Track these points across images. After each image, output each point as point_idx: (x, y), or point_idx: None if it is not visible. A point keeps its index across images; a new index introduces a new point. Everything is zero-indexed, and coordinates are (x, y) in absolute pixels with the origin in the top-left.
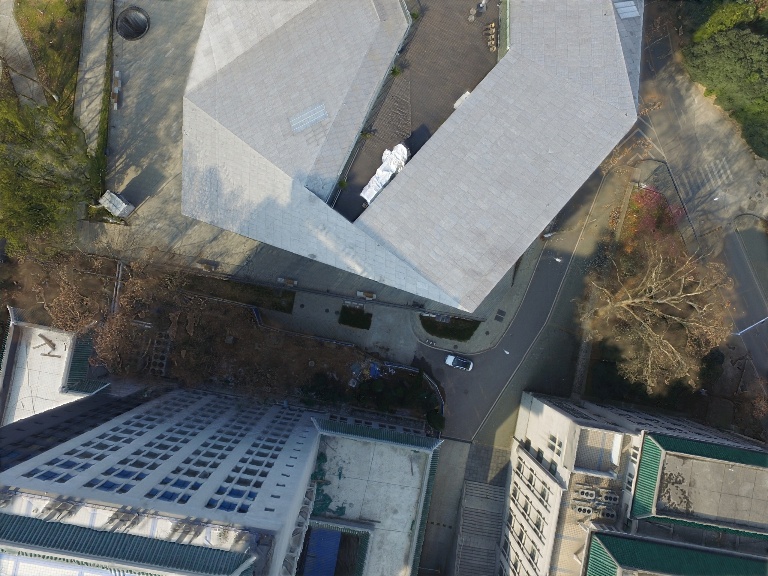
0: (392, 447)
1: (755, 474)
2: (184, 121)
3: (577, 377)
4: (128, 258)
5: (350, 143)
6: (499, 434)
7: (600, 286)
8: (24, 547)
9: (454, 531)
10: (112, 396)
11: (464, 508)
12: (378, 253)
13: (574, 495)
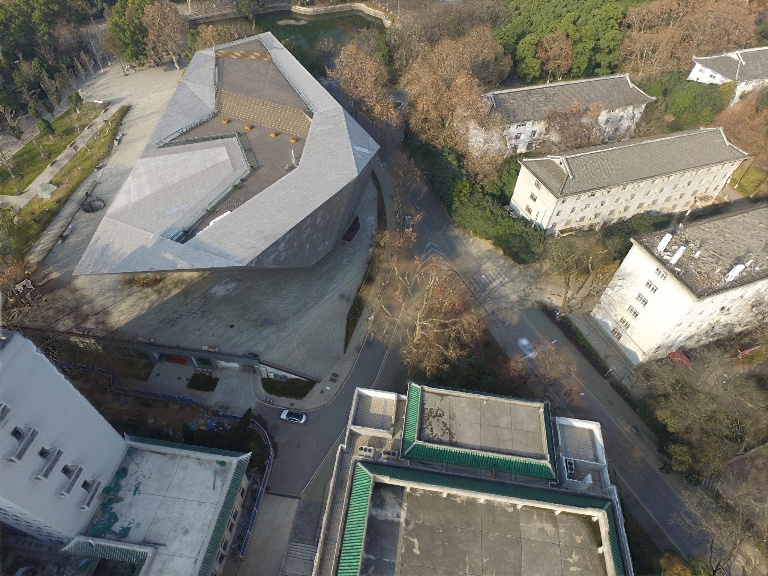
0: (198, 461)
1: (509, 408)
2: (99, 227)
3: None
4: None
5: (199, 217)
6: None
7: None
8: None
9: None
10: None
11: (282, 572)
12: (194, 253)
13: None
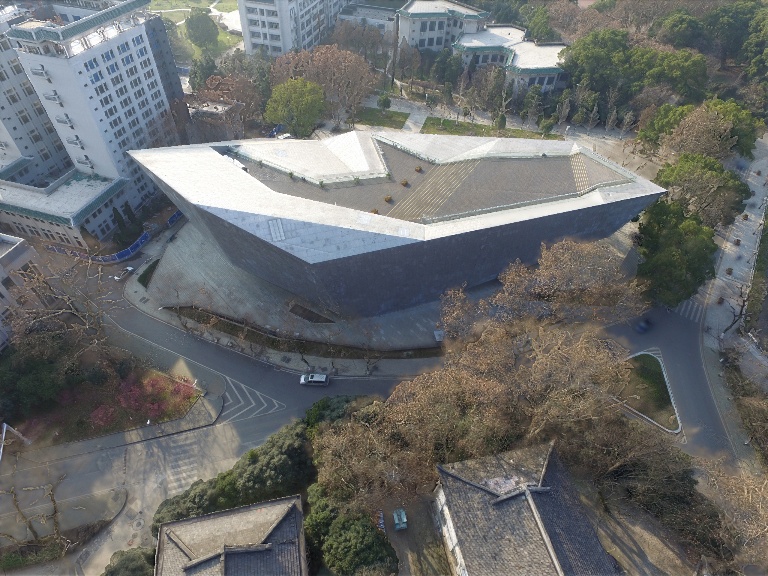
0: None
1: None
2: None
3: None
4: None
5: None
6: None
7: None
8: None
9: None
10: None
11: None
12: None
13: None
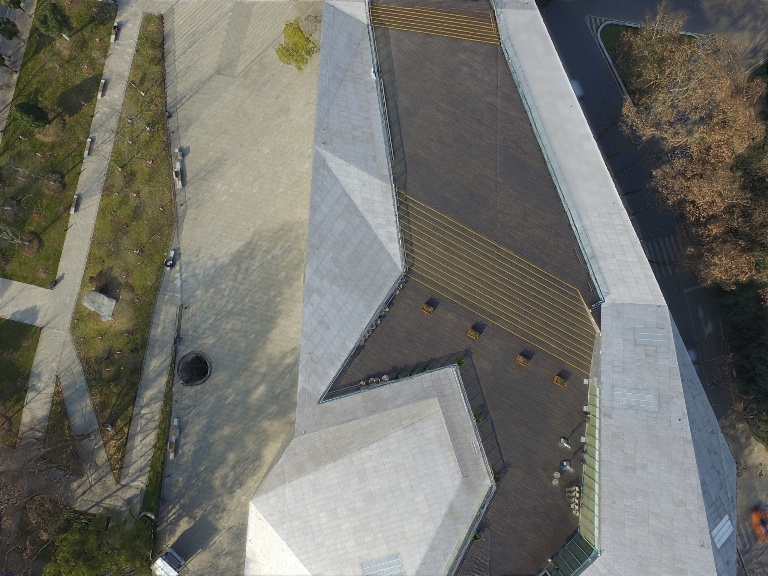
0: None
1: None
2: (249, 527)
3: None
4: None
5: None
6: None
7: None
8: None
9: None
10: None
11: None
12: None
13: None
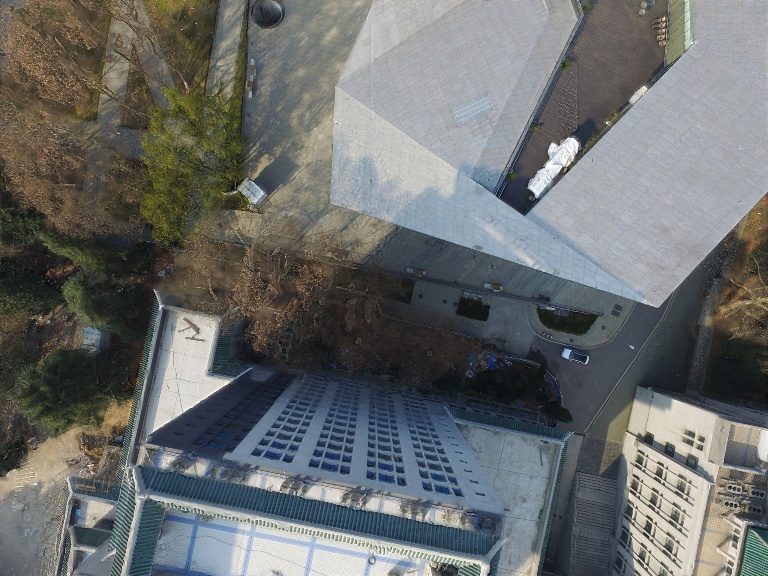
0: (522, 437)
1: None
2: (336, 111)
3: (693, 373)
4: (261, 245)
5: (517, 136)
6: (612, 428)
7: (721, 283)
8: (295, 522)
9: (565, 521)
10: (254, 380)
11: (577, 499)
12: (553, 246)
13: (718, 489)
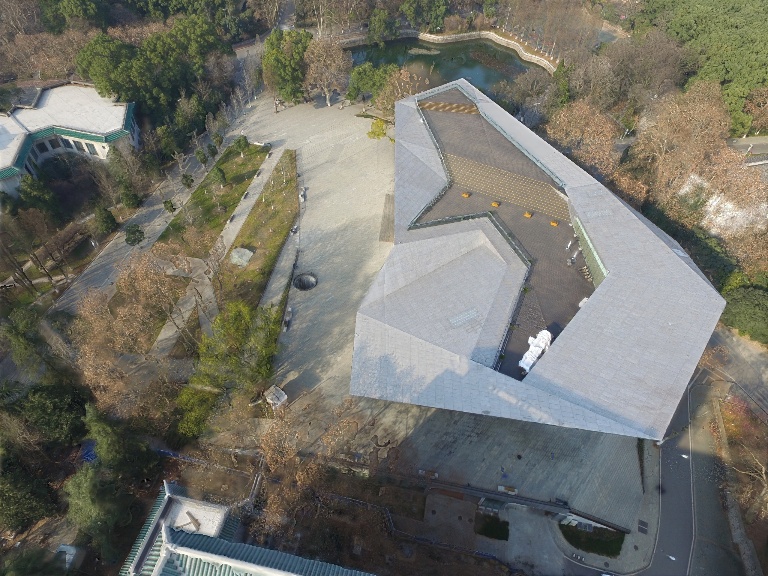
0: None
1: None
2: (357, 327)
3: None
4: None
5: (501, 332)
6: None
7: None
8: None
9: None
10: None
11: None
12: (552, 401)
13: None
